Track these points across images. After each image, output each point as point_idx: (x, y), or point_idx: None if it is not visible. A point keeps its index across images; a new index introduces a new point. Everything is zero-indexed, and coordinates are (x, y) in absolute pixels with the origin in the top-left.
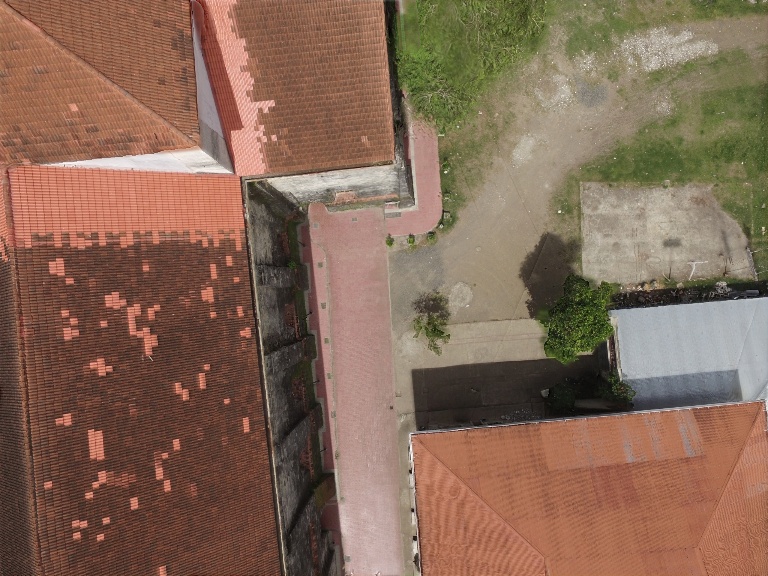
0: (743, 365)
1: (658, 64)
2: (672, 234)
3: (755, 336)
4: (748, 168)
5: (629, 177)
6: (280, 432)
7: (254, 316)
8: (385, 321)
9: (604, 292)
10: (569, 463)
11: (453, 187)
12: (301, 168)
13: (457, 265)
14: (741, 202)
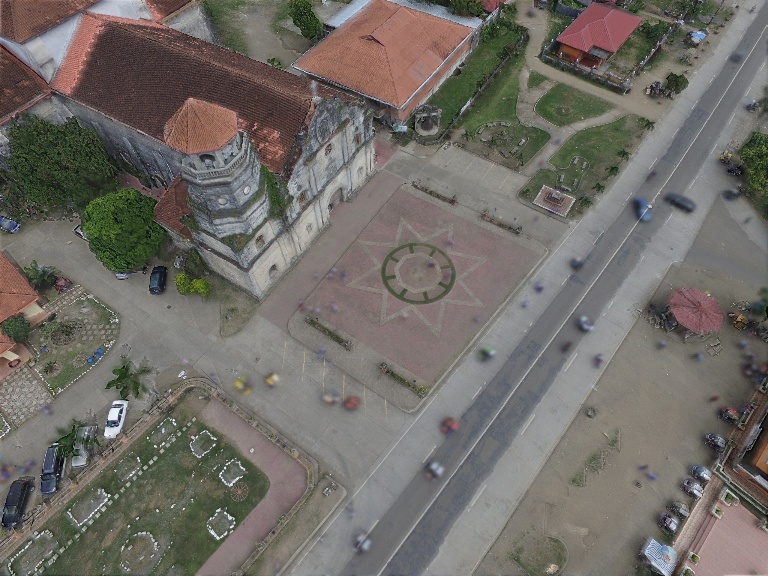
0: None
1: None
2: (317, 14)
3: None
4: None
5: (287, 14)
6: None
7: None
8: None
9: None
10: None
11: None
12: (171, 11)
13: None
14: None
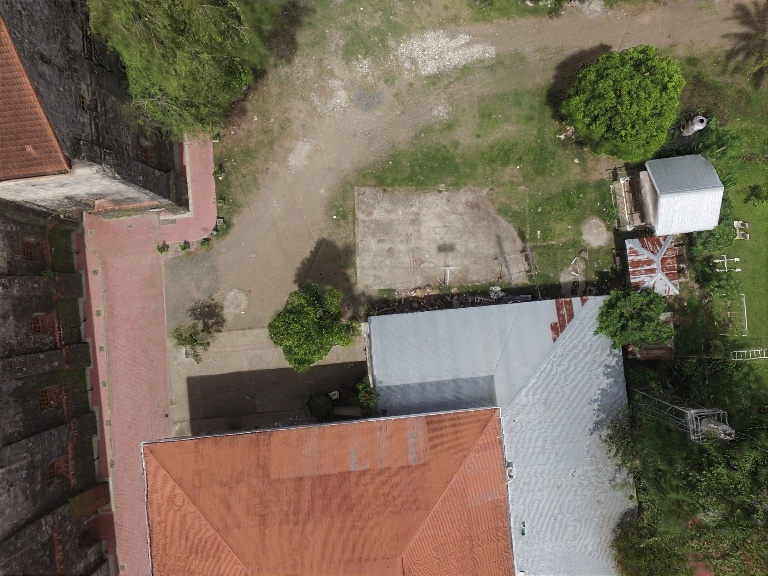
0: (499, 371)
1: (435, 68)
2: (447, 239)
3: (513, 341)
4: (524, 172)
5: (404, 182)
6: None
7: None
8: (160, 328)
9: (331, 299)
10: (292, 472)
11: (228, 193)
12: None
13: (232, 271)
14: (517, 206)
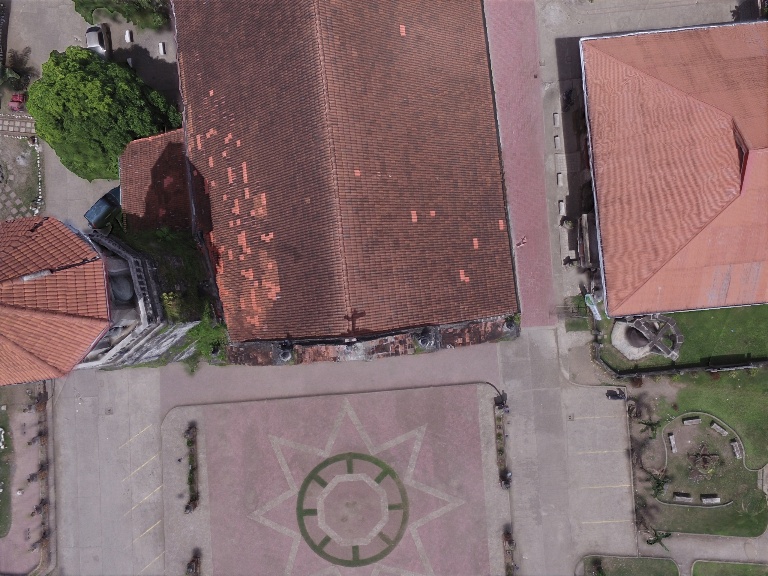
0: None
1: None
2: None
3: None
4: None
5: None
6: None
7: None
8: None
9: None
10: (743, 54)
11: None
12: None
13: None
14: None
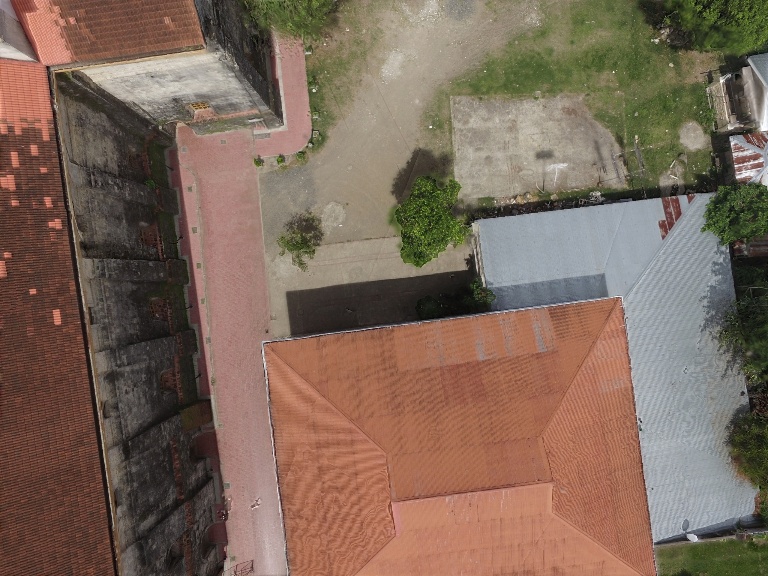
0: (610, 269)
1: None
2: (544, 145)
3: (622, 240)
4: (619, 76)
5: (499, 89)
6: (121, 341)
7: (66, 208)
8: (257, 244)
9: (452, 190)
10: (419, 363)
11: (322, 106)
12: (109, 55)
13: (329, 184)
14: (613, 111)
